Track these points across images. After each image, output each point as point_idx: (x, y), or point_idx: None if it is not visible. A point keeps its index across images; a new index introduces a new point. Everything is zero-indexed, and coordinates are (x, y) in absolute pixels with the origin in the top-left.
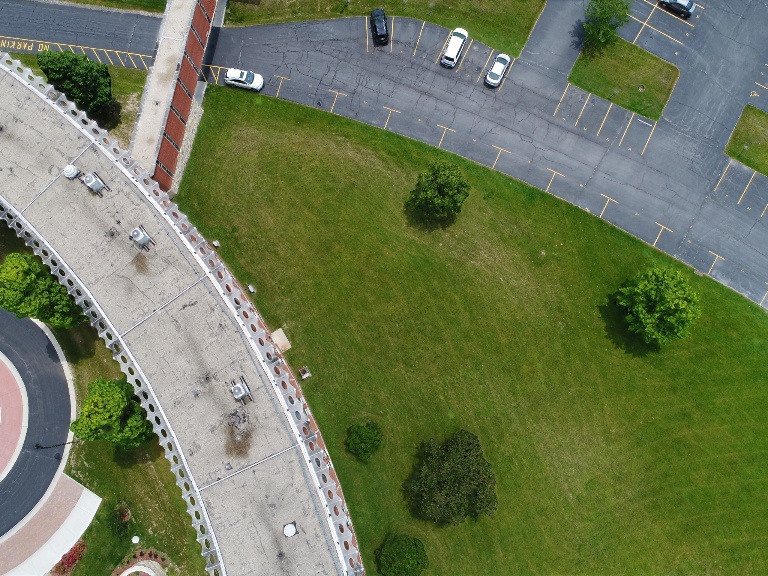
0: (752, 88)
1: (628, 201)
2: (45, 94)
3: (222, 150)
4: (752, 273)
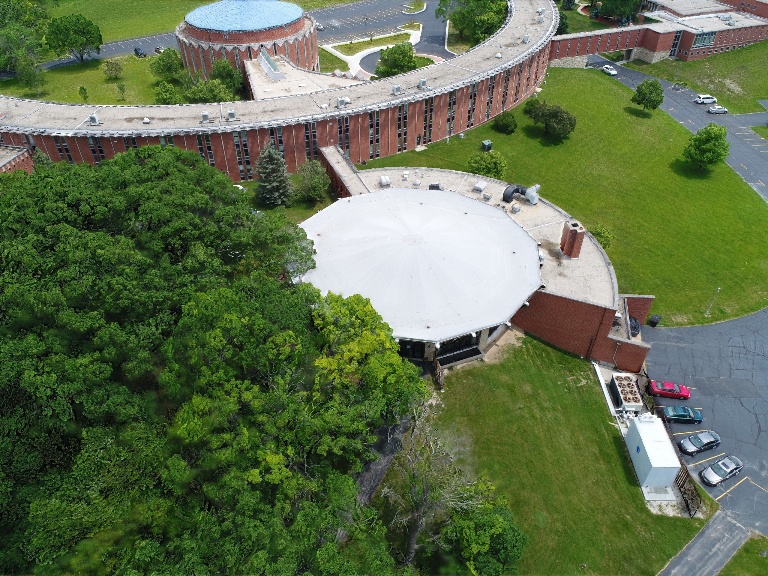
0: None
1: (735, 154)
2: (552, 5)
3: None
4: None
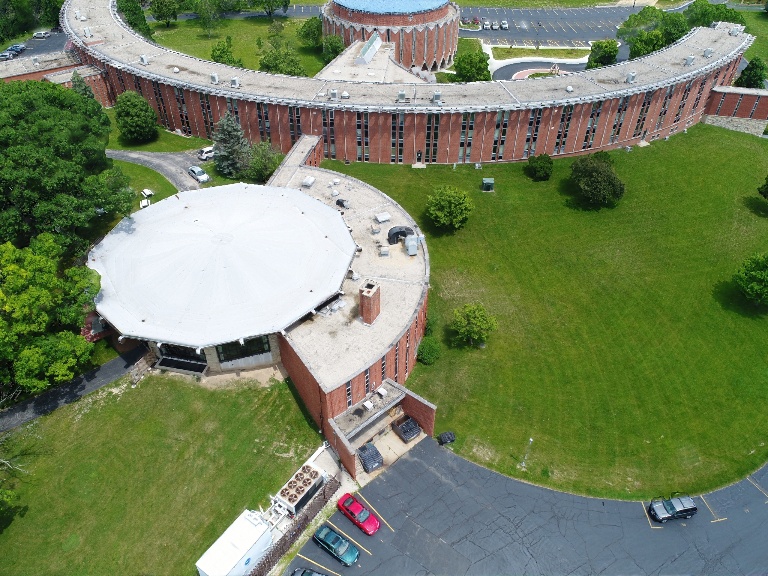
0: None
1: None
2: None
3: (742, 138)
4: None
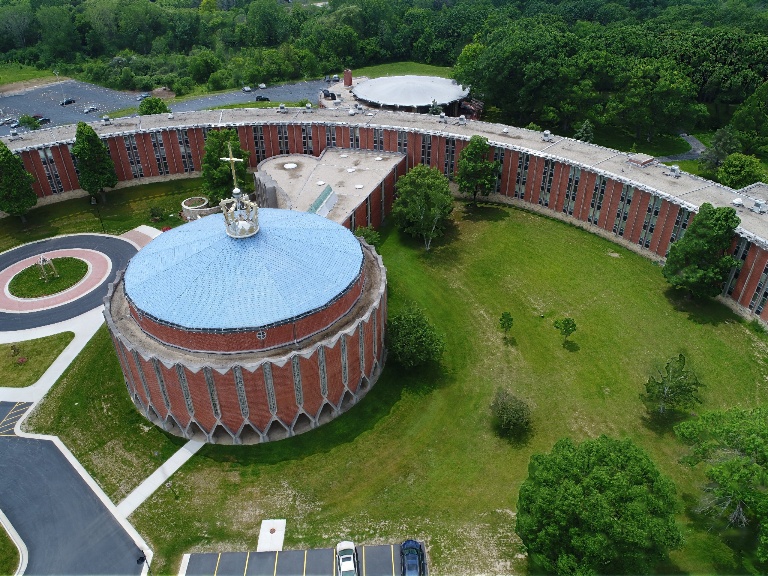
0: (92, 116)
1: None
2: None
3: None
4: None
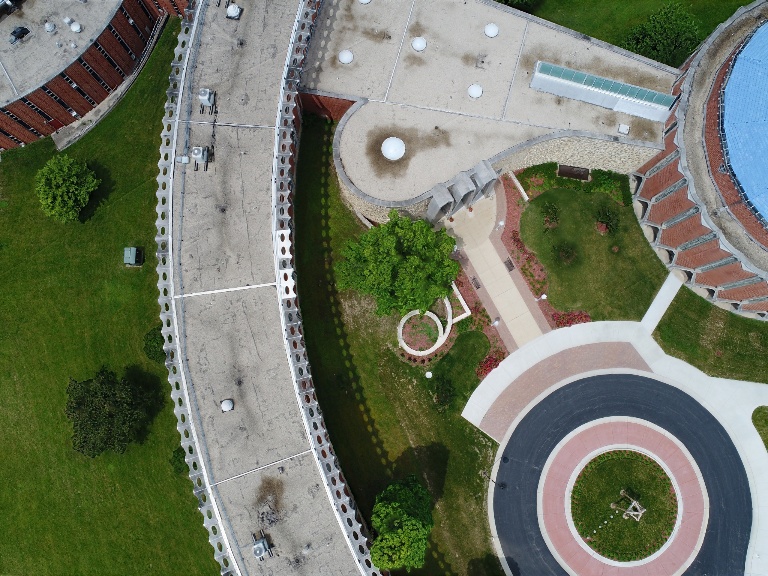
0: None
1: None
2: None
3: None
4: None
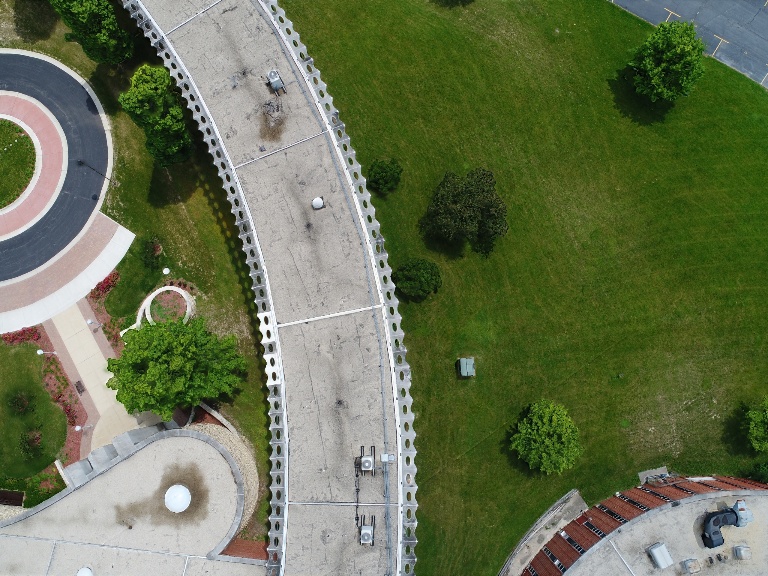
0: None
1: None
2: None
3: None
4: (754, 55)
